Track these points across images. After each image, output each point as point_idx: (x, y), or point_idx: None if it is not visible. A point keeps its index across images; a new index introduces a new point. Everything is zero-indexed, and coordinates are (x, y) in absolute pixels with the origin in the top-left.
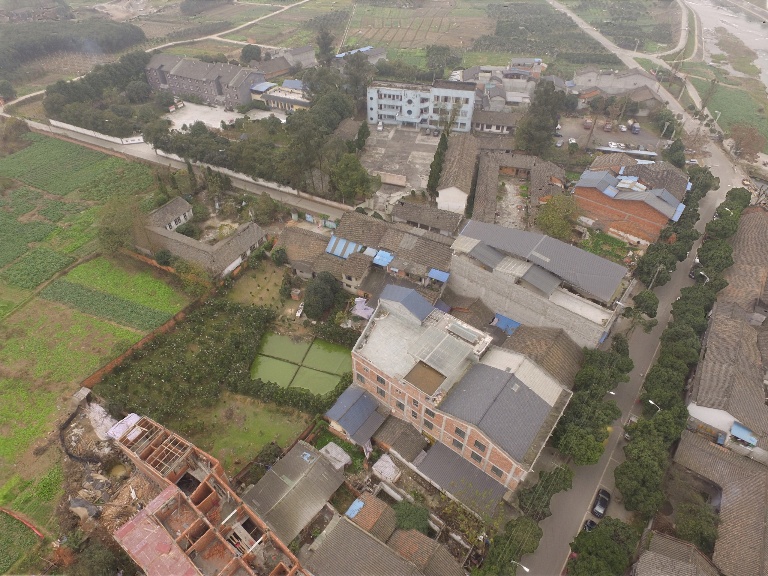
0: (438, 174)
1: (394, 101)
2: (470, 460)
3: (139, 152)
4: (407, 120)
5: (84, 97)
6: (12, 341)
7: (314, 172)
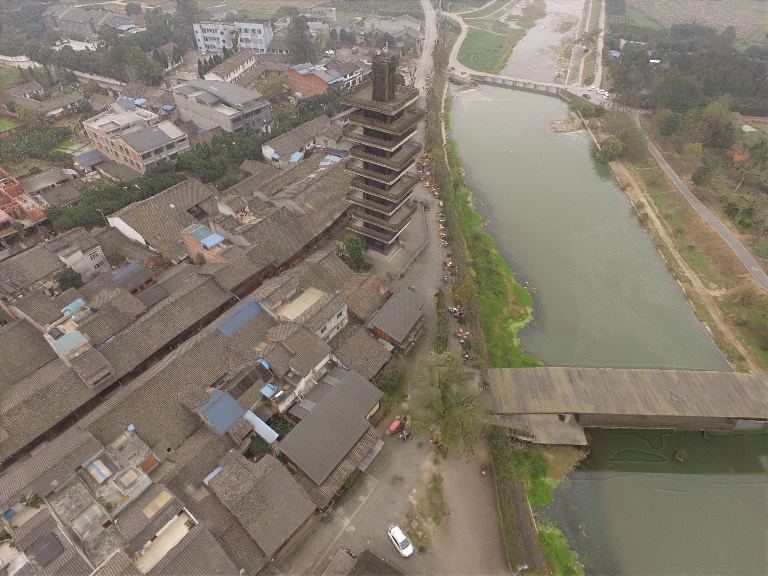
0: (208, 68)
1: (213, 34)
2: (133, 167)
3: (23, 65)
4: (222, 47)
5: None
6: None
7: (122, 64)
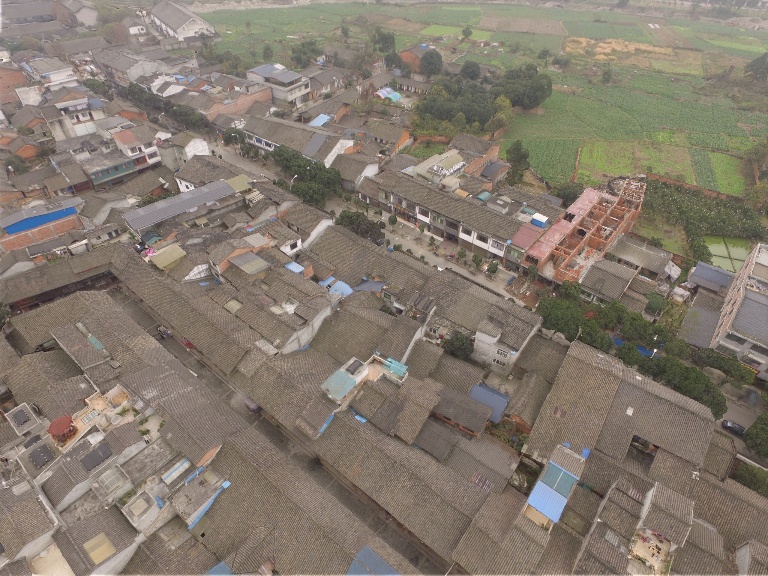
0: None
1: None
2: None
3: None
4: None
5: None
6: (654, 150)
7: None
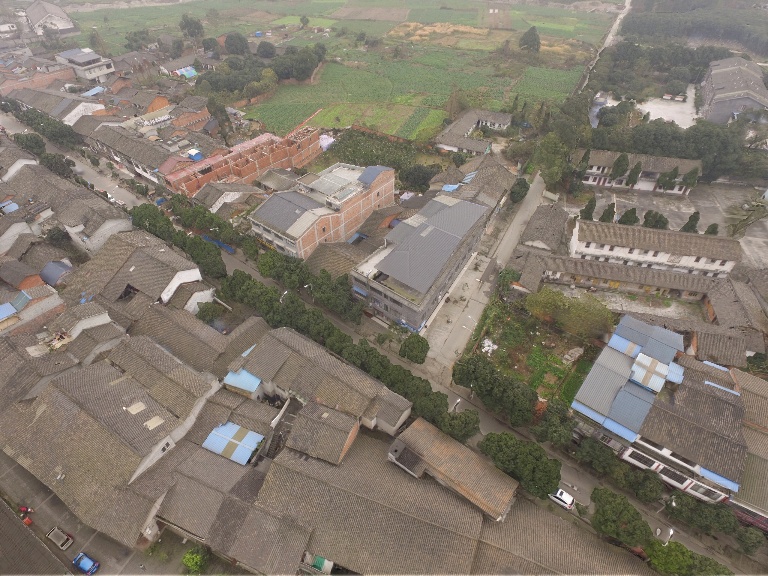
0: (607, 217)
1: None
2: None
3: None
4: None
5: (634, 60)
6: (385, 109)
7: None
